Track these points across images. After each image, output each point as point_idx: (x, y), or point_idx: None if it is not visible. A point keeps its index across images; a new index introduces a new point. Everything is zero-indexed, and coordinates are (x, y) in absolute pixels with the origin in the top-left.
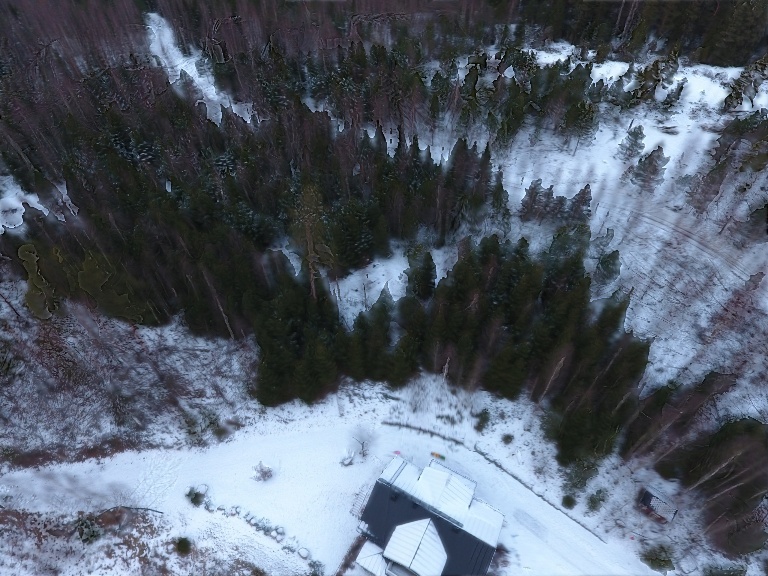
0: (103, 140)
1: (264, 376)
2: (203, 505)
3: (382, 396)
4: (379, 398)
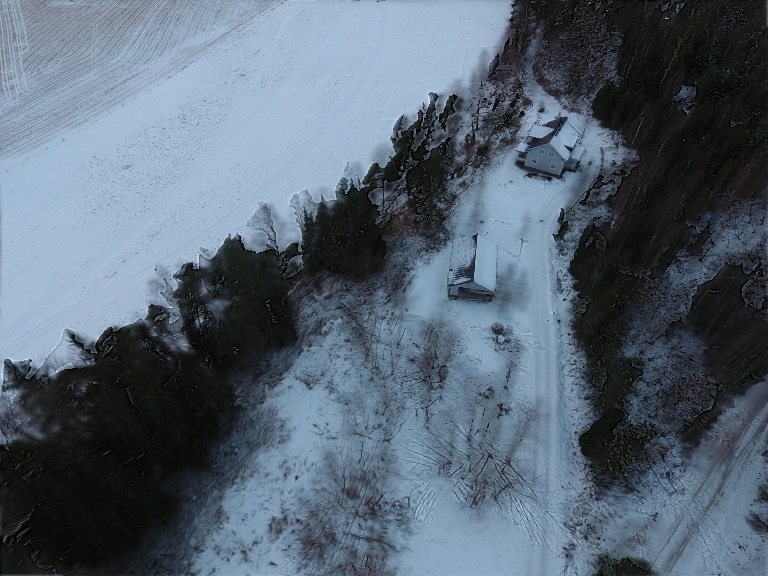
0: (731, 6)
1: (604, 88)
2: (539, 112)
3: (617, 142)
4: (615, 142)
